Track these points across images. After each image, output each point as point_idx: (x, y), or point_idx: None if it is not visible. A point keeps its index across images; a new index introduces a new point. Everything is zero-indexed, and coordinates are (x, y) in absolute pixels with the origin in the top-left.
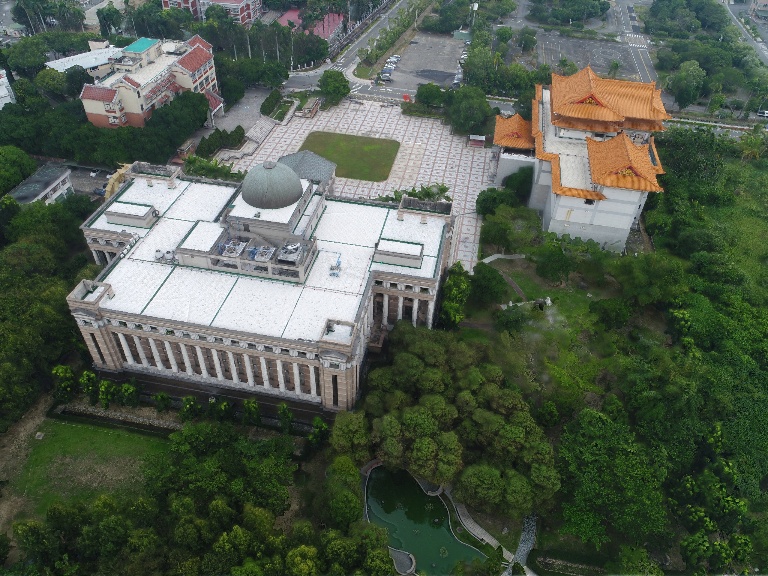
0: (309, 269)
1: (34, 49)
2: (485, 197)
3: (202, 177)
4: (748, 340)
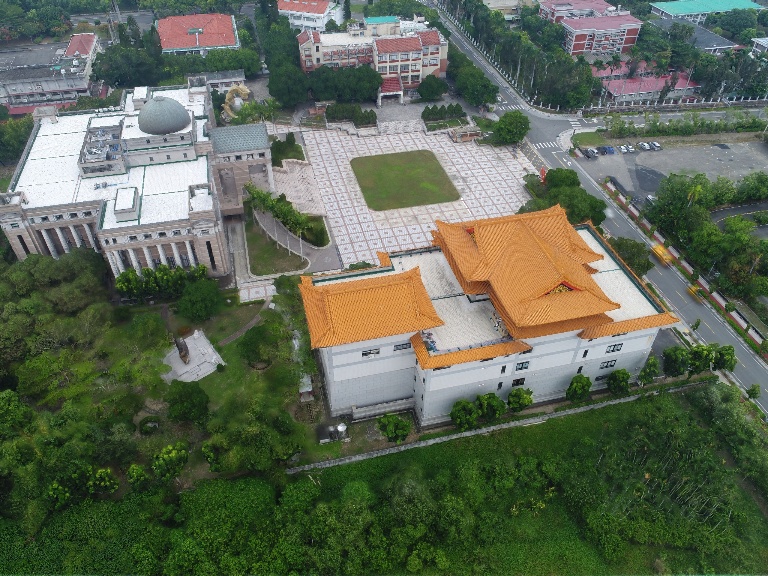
0: (100, 175)
1: (385, 7)
2: (354, 266)
3: (261, 118)
4: (186, 560)
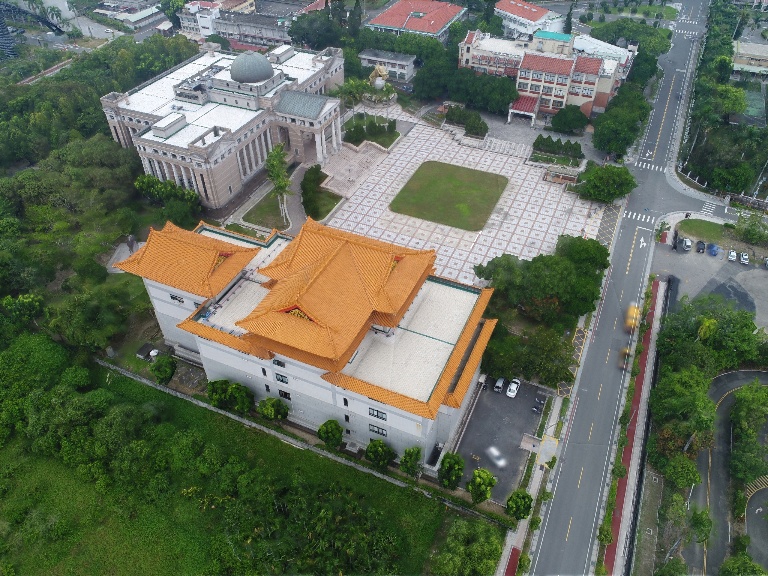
0: (186, 100)
1: (613, 28)
2: None
3: (373, 98)
4: None
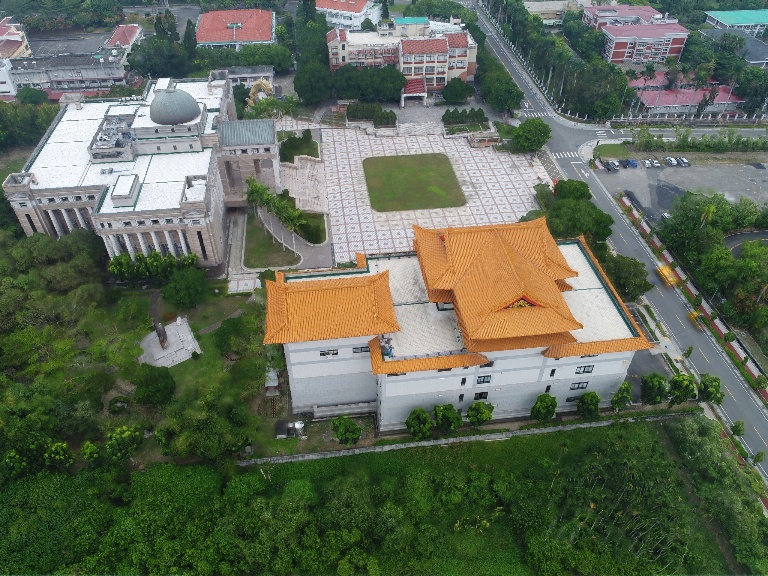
0: (109, 161)
1: (424, 8)
2: (341, 265)
3: (279, 113)
4: (123, 539)
